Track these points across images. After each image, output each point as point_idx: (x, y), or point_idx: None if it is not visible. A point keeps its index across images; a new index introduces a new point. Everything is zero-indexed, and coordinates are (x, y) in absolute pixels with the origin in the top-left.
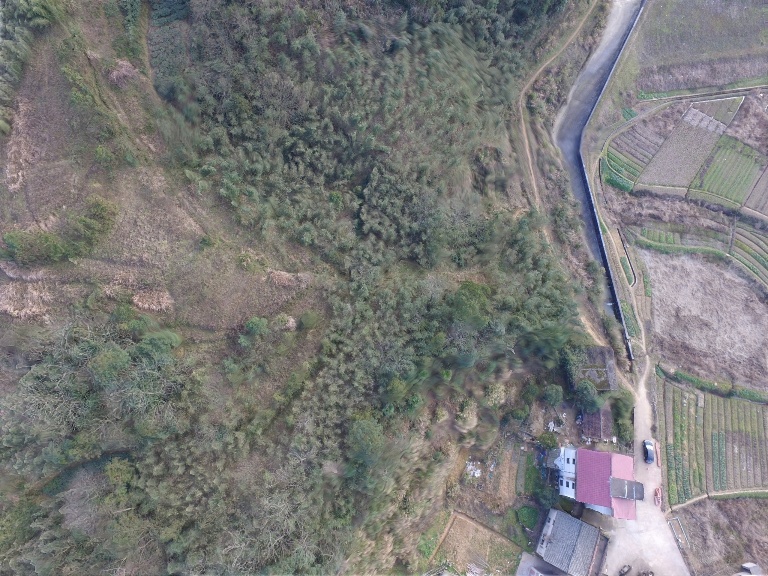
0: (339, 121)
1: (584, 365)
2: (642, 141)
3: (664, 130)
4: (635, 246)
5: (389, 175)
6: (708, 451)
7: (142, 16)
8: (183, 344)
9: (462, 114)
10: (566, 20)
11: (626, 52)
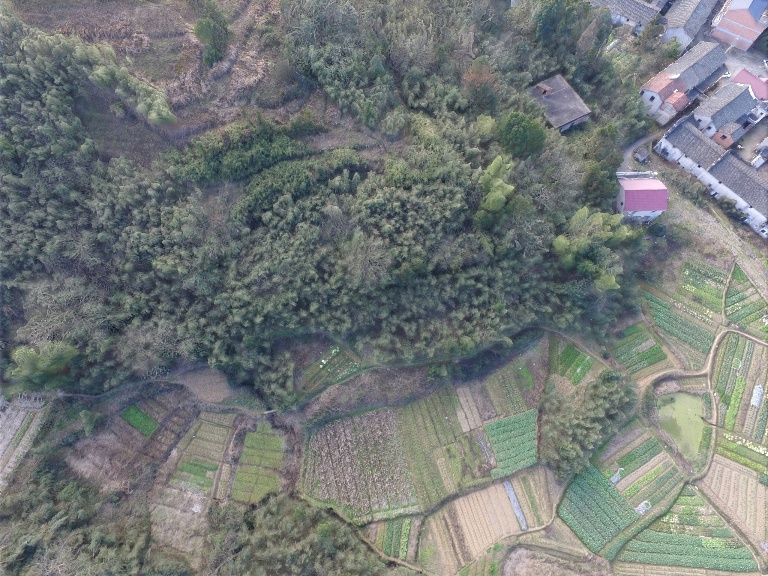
0: None
1: None
2: None
3: None
4: None
5: None
6: None
7: None
8: None
9: None
10: None
11: None
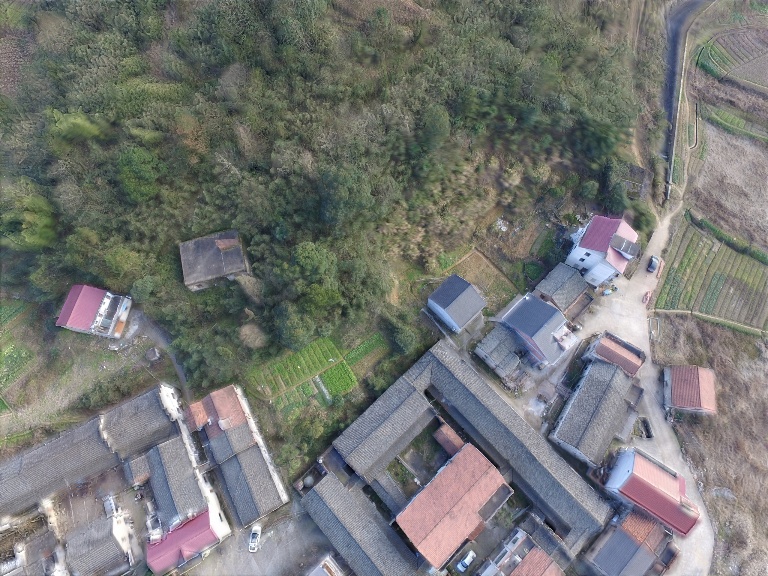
0: None
1: (624, 176)
2: (749, 45)
3: None
4: (707, 122)
5: None
6: (706, 283)
7: None
8: (332, 18)
9: None
10: None
11: None
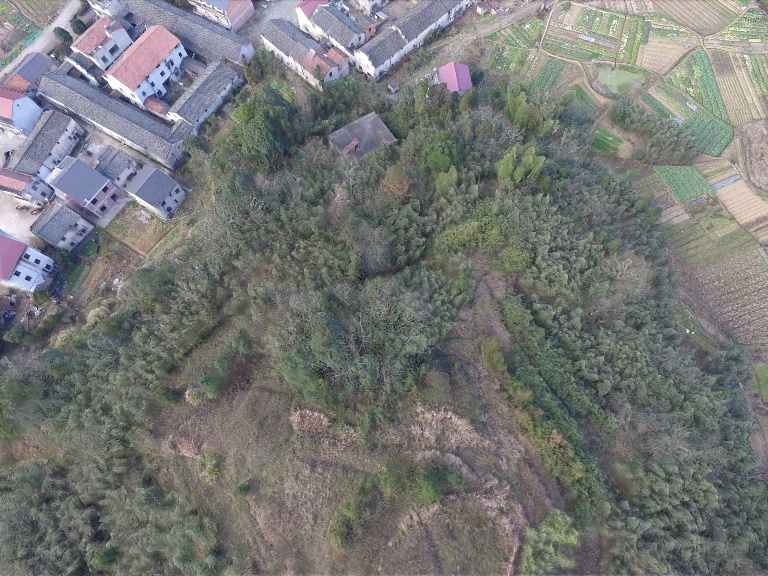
0: None
1: None
2: None
3: None
4: None
5: None
6: None
7: None
8: None
9: None
10: None
11: None
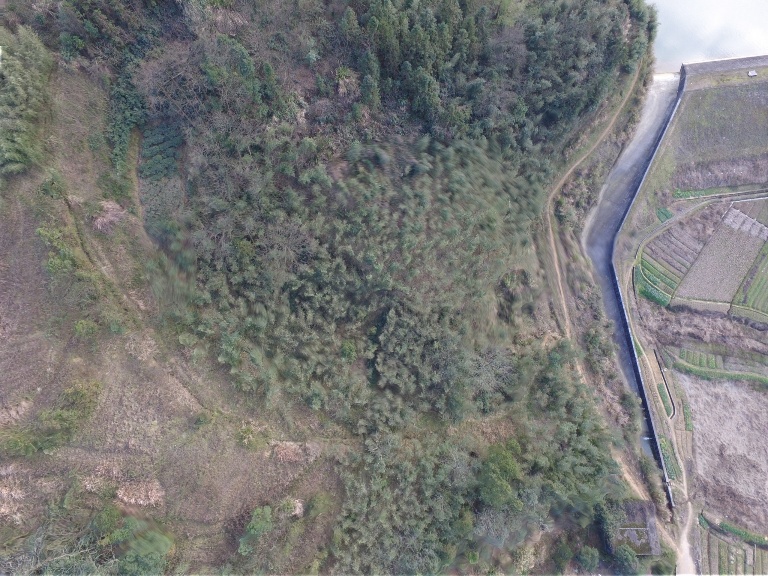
0: (352, 256)
1: (622, 524)
2: (679, 247)
3: (703, 234)
4: (673, 370)
5: (408, 318)
6: None
7: (131, 146)
8: (175, 542)
9: (488, 242)
10: (598, 117)
11: (662, 148)
